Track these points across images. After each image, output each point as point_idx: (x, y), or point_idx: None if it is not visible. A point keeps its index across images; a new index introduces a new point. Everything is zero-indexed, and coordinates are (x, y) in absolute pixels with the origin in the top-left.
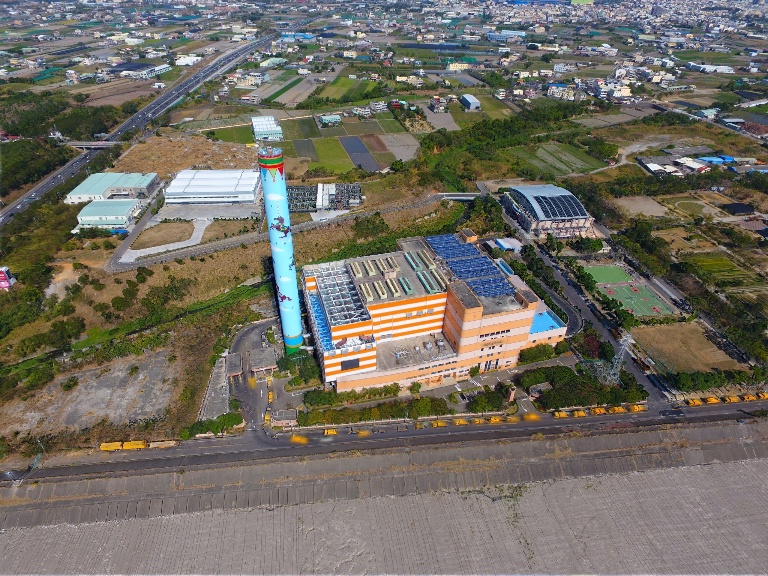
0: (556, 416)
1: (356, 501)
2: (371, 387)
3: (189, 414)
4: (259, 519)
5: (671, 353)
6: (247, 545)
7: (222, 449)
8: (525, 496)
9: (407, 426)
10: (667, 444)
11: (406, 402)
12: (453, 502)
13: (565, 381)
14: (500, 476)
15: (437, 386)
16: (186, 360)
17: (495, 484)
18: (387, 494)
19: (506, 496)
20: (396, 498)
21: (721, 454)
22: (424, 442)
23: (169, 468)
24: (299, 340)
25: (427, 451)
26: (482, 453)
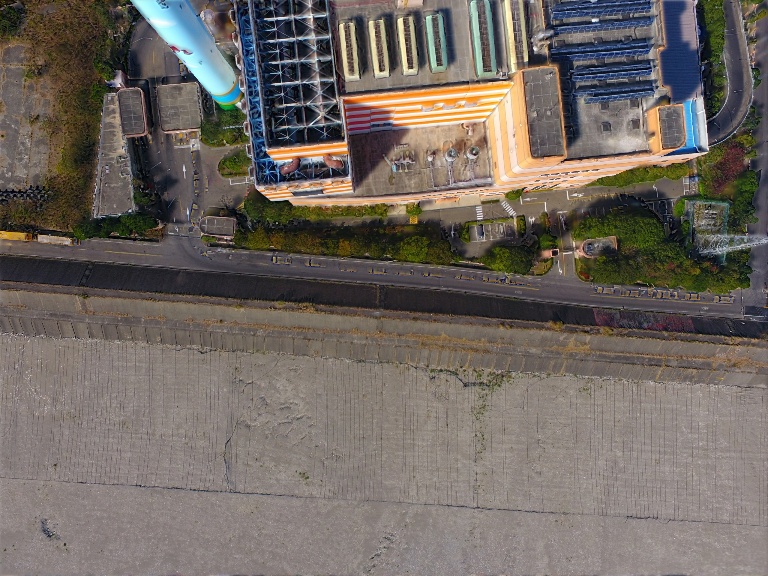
0: (597, 292)
1: (304, 359)
2: (345, 205)
3: (81, 195)
4: (190, 361)
5: None
6: (178, 388)
7: (136, 259)
8: (504, 388)
9: (387, 269)
10: (718, 360)
11: (395, 228)
12: (417, 380)
13: (641, 247)
14: (484, 361)
15: (449, 205)
16: (57, 78)
17: (475, 367)
18: (342, 357)
19: (482, 383)
20: (352, 363)
21: None
22: (402, 303)
23: (67, 288)
24: (232, 96)
25: (402, 321)
26: (473, 333)
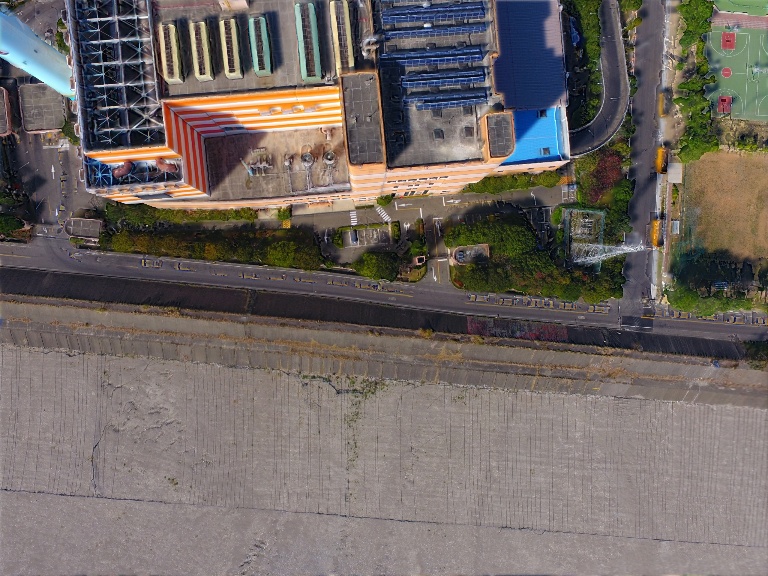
0: (471, 300)
1: (174, 364)
2: (209, 209)
3: None
4: (58, 364)
5: (722, 216)
6: (45, 392)
7: (4, 260)
8: (377, 395)
9: (258, 273)
10: (592, 370)
11: (266, 233)
12: (289, 386)
13: (511, 255)
14: (356, 368)
15: (322, 209)
16: None
17: (348, 374)
18: (213, 362)
19: (355, 390)
20: (223, 369)
21: (652, 392)
22: (271, 308)
23: None
24: None
25: (269, 326)
26: (342, 340)
